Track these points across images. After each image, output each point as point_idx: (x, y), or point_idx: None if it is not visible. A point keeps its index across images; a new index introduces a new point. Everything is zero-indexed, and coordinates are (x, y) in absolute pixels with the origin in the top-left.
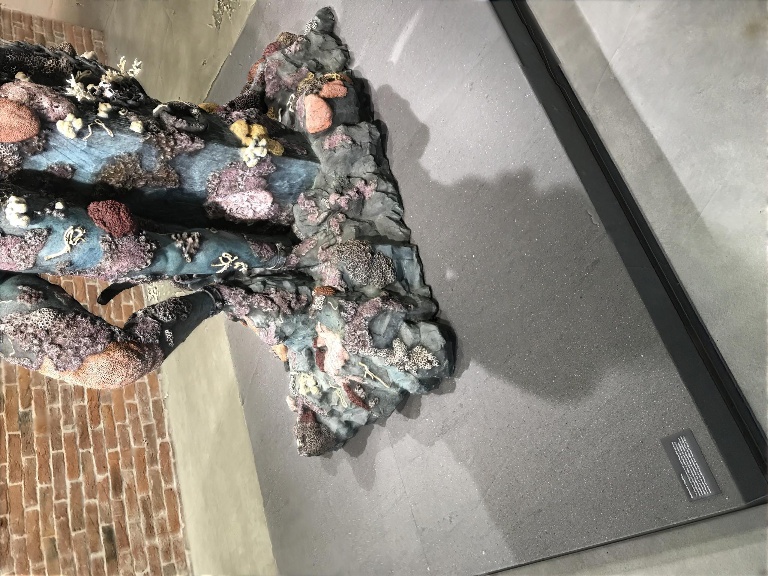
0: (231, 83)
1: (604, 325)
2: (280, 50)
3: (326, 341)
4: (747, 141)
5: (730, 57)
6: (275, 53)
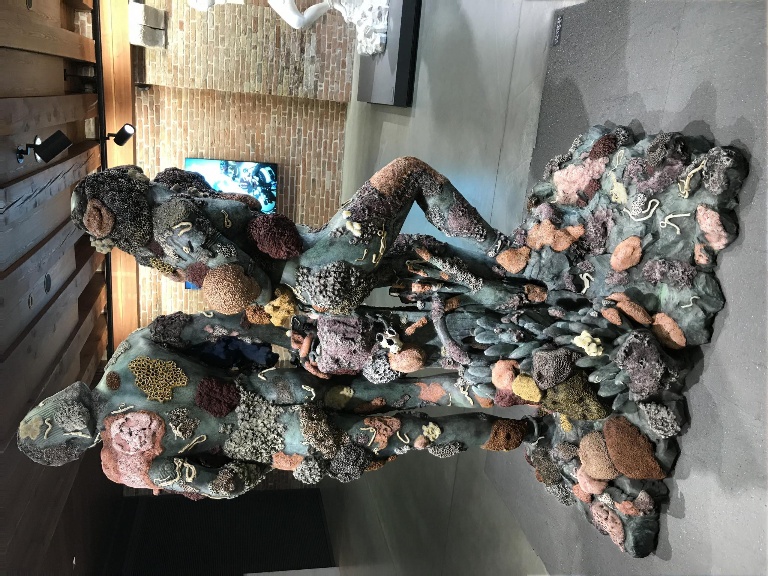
0: None
1: None
2: None
3: (569, 192)
4: None
5: None
6: None
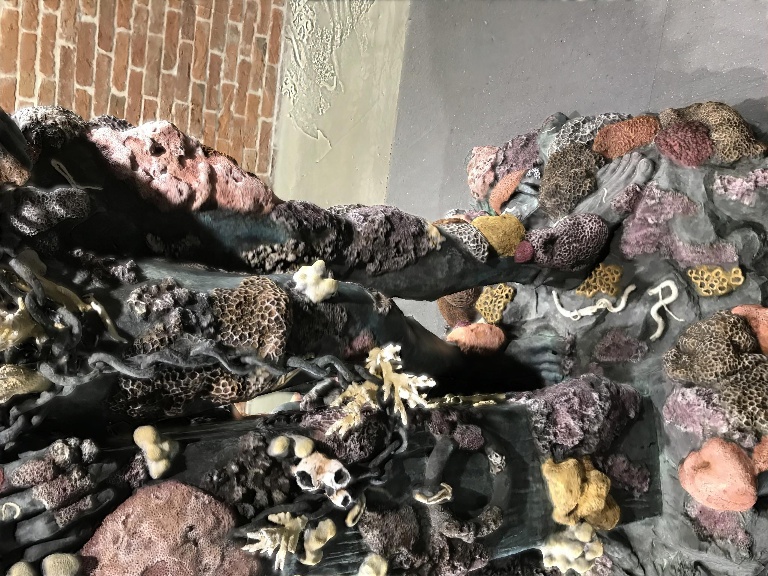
0: None
1: None
2: (704, 172)
3: None
4: None
5: None
6: (689, 169)
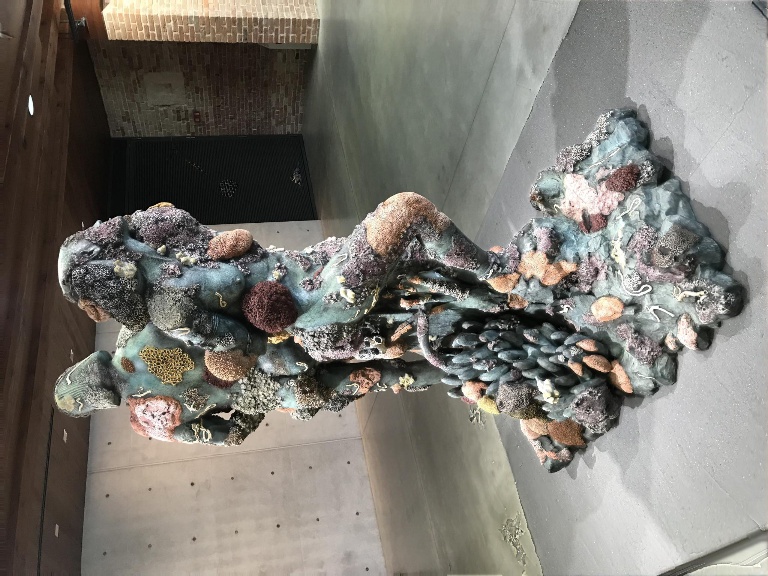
0: (528, 486)
1: (593, 6)
2: None
3: (575, 206)
4: (571, 6)
5: (552, 34)
6: None
